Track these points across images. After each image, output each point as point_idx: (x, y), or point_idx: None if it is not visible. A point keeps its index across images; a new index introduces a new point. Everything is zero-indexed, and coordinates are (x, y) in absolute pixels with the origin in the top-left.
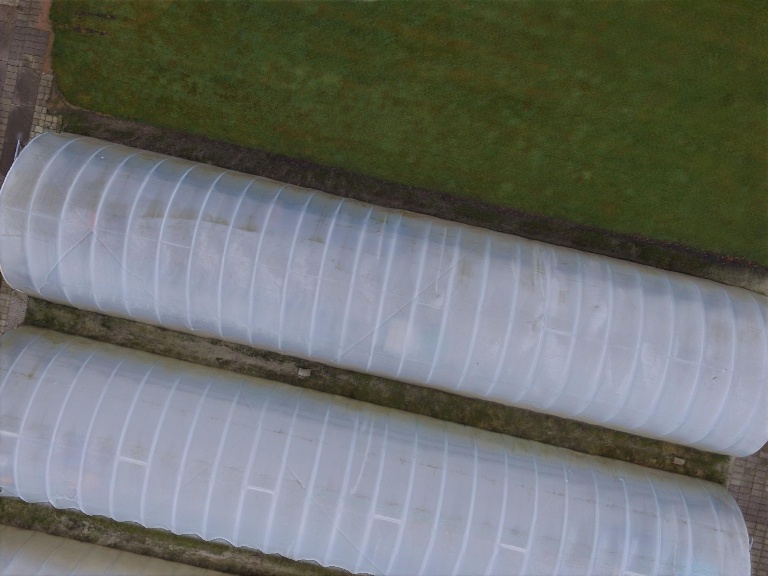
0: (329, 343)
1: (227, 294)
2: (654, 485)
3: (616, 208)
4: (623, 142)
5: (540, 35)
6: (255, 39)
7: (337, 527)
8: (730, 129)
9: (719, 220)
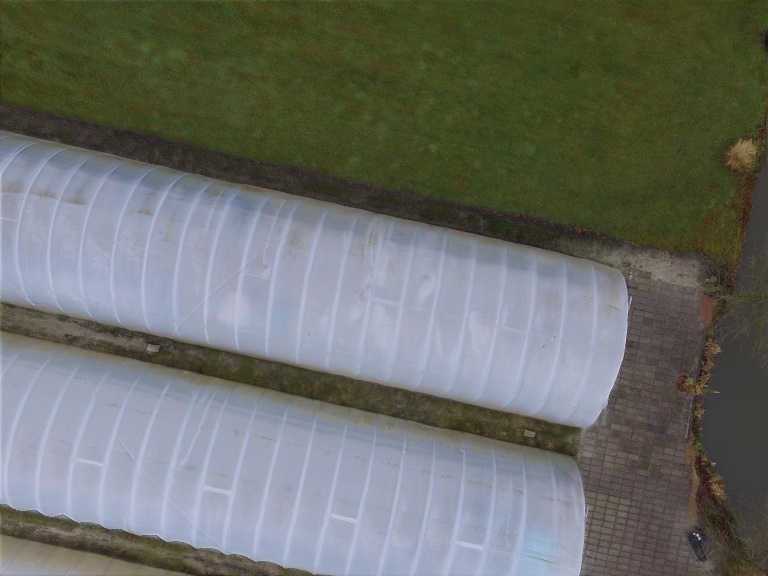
0: (163, 316)
1: (56, 267)
2: (497, 456)
3: (463, 181)
4: (468, 116)
5: (384, 11)
6: (102, 18)
7: (167, 499)
8: (575, 102)
9: (566, 192)
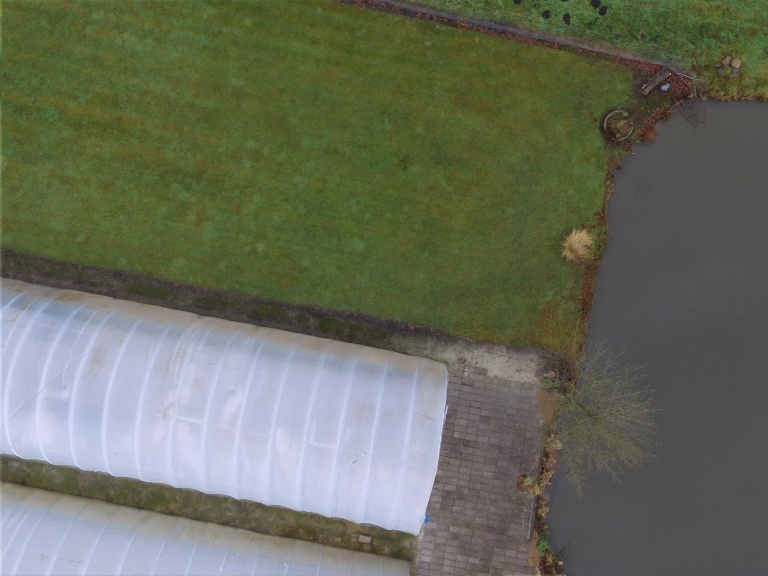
0: None
1: None
2: (322, 569)
3: (291, 280)
4: (294, 213)
5: (205, 107)
6: None
7: None
8: (403, 195)
9: (397, 288)
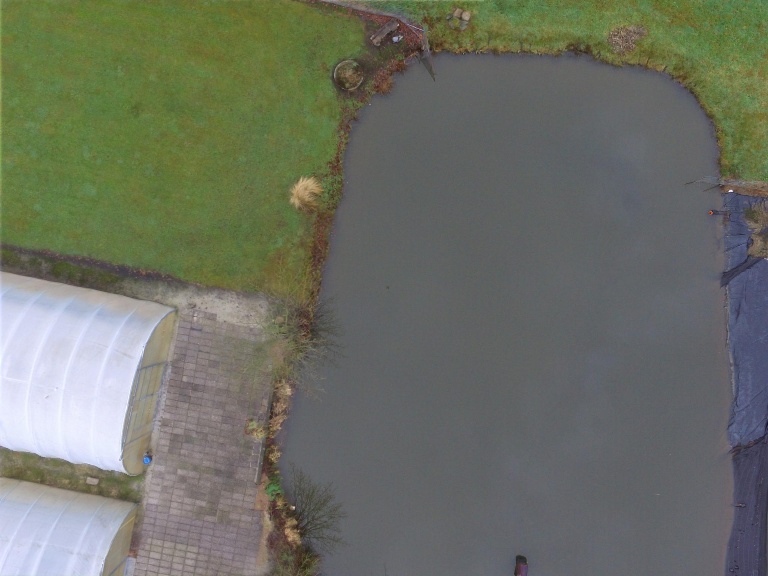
0: None
1: None
2: (35, 507)
3: (23, 224)
4: (26, 158)
5: None
6: None
7: None
8: (135, 142)
9: (129, 234)
